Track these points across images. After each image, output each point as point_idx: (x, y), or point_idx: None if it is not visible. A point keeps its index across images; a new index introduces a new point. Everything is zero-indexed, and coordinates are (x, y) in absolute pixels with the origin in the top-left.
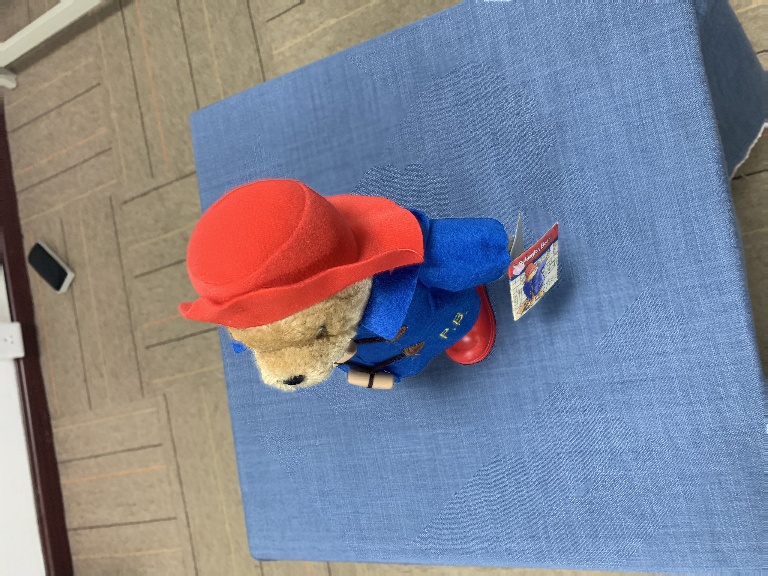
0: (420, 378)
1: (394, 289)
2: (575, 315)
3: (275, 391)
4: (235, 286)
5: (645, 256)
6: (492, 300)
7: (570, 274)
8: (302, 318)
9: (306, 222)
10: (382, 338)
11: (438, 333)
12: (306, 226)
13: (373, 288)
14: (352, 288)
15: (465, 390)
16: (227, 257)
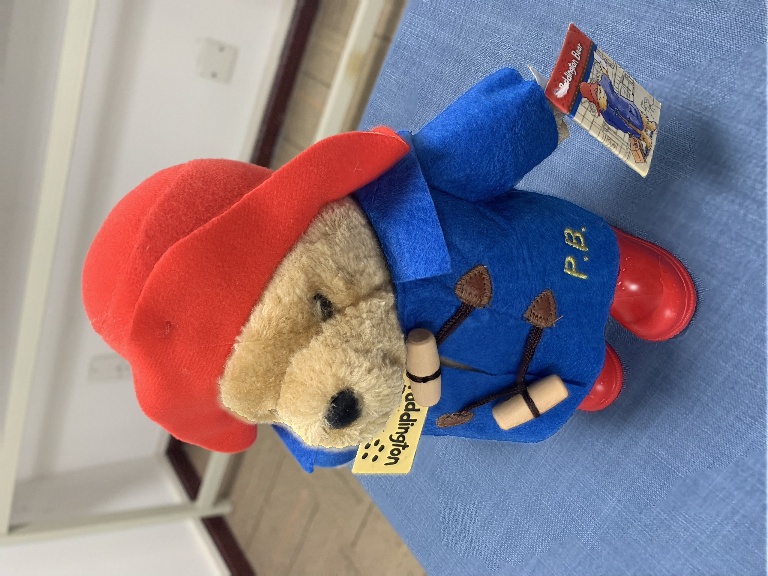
0: (648, 404)
1: (400, 207)
2: (749, 145)
3: (510, 575)
4: (122, 287)
5: (755, 6)
6: (639, 234)
7: (694, 116)
8: (269, 295)
9: (188, 170)
10: (465, 306)
11: (558, 268)
12: (189, 173)
13: (374, 226)
14: (322, 224)
15: (715, 365)
16: (100, 263)
